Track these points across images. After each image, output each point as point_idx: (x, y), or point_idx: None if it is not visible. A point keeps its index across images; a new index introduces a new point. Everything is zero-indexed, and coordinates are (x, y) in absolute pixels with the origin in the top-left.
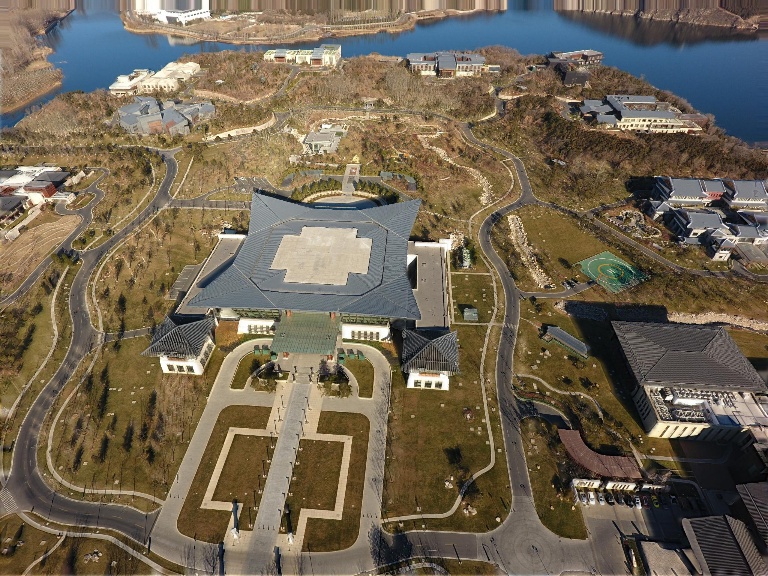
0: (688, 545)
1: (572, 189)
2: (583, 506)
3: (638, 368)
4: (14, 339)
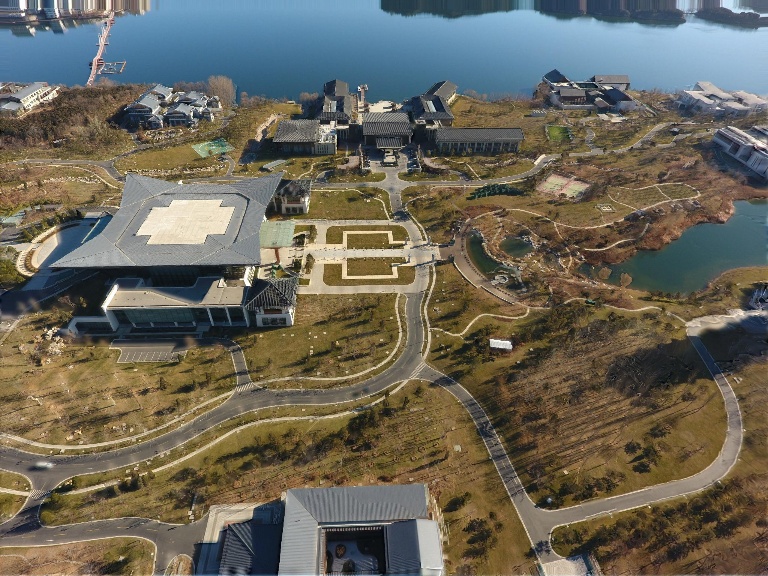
0: (384, 154)
1: (103, 145)
2: (372, 172)
3: (307, 140)
4: (258, 437)
